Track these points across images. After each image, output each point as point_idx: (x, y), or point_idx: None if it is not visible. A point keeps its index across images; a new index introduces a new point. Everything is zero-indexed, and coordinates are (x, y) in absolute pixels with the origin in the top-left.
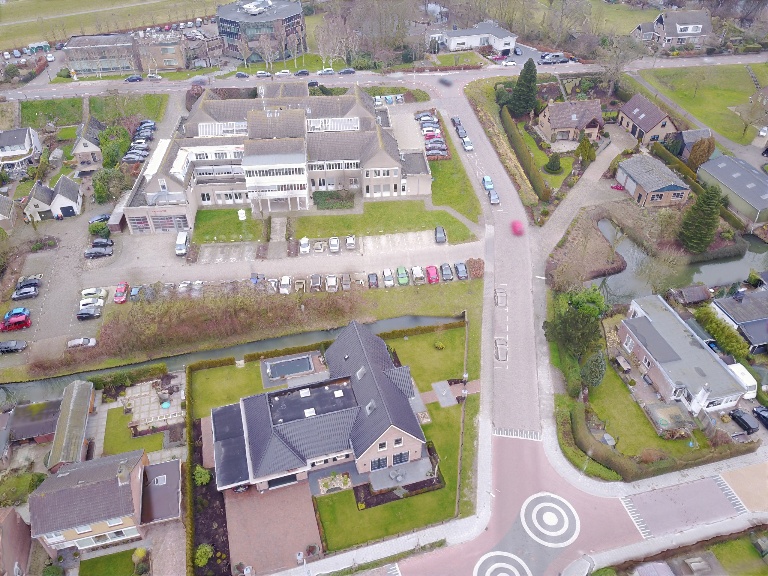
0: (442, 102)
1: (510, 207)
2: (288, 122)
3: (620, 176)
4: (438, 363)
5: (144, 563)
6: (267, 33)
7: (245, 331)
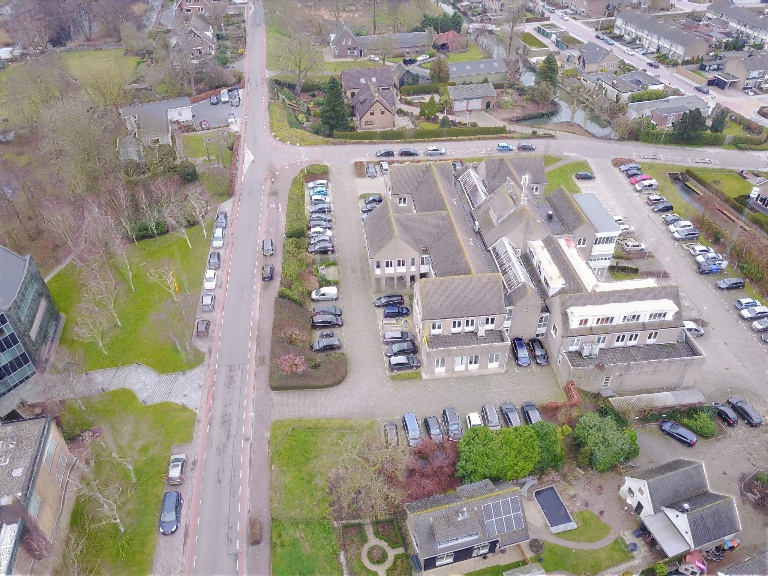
0: (334, 159)
1: (534, 143)
2: None
3: (459, 106)
4: (733, 182)
5: None
6: (31, 296)
7: None
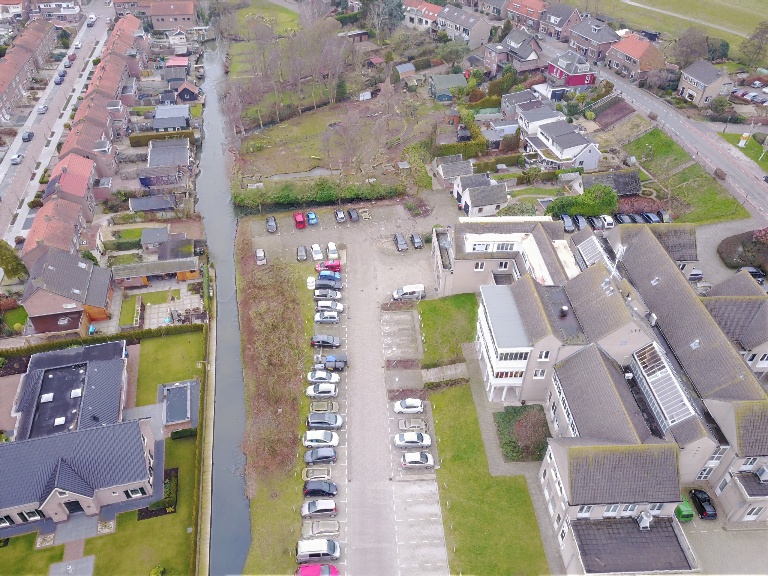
0: None
1: None
2: (604, 312)
3: None
4: (126, 568)
5: (6, 329)
6: None
7: (254, 364)
